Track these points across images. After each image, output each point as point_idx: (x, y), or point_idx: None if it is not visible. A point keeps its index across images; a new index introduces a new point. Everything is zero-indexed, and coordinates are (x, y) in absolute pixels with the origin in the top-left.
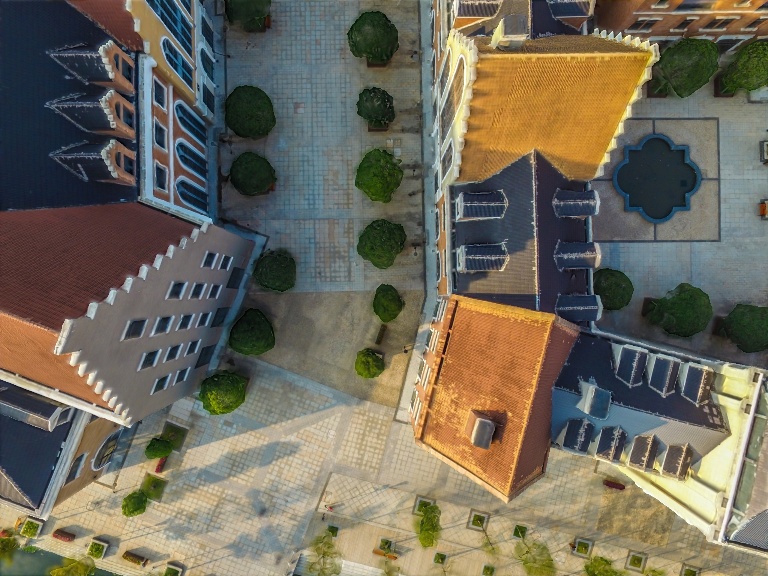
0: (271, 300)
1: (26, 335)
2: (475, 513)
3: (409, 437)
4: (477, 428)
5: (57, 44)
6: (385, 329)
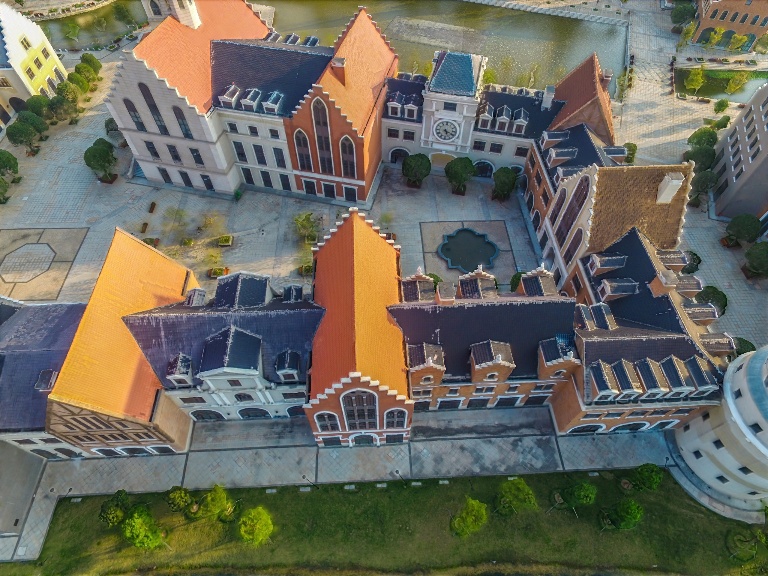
0: None
1: None
2: None
3: None
4: None
5: None
6: None
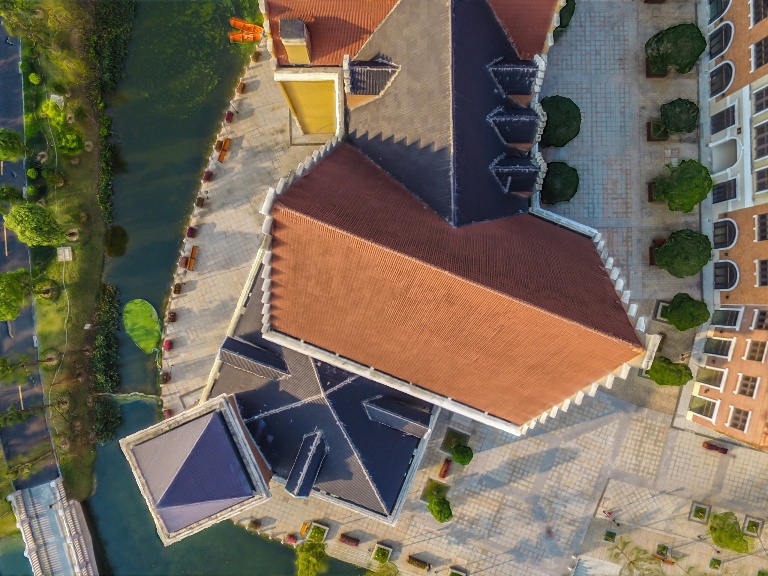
0: None
1: (567, 348)
2: (750, 519)
3: (686, 444)
4: None
5: (490, 58)
6: (665, 337)
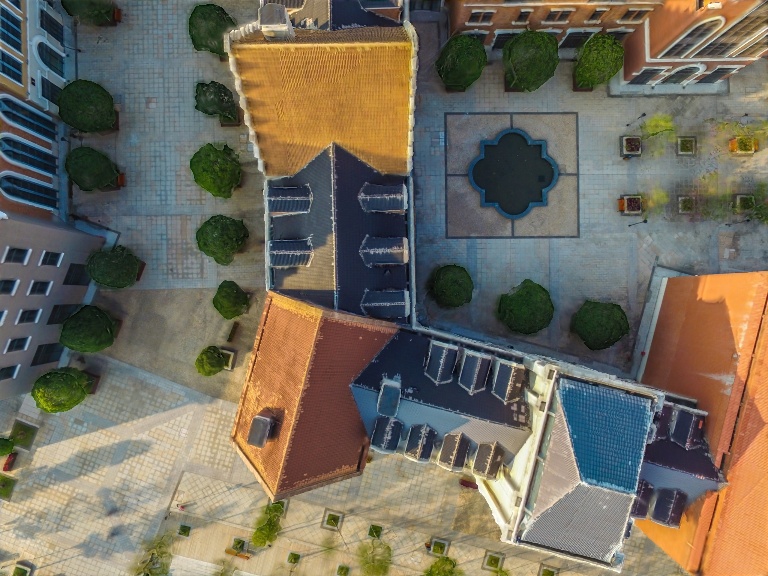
0: (122, 297)
1: None
2: (329, 512)
3: None
4: (251, 426)
5: None
6: (237, 326)
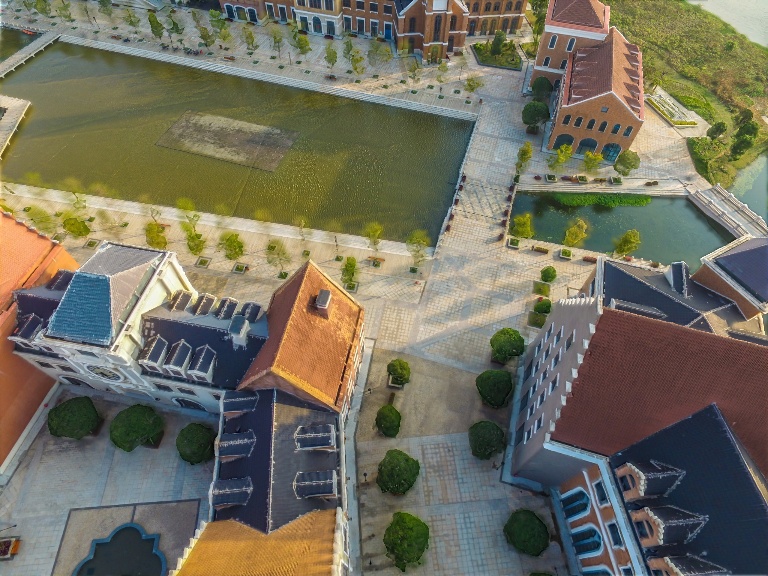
0: None
1: None
2: None
3: None
4: None
5: None
6: None
